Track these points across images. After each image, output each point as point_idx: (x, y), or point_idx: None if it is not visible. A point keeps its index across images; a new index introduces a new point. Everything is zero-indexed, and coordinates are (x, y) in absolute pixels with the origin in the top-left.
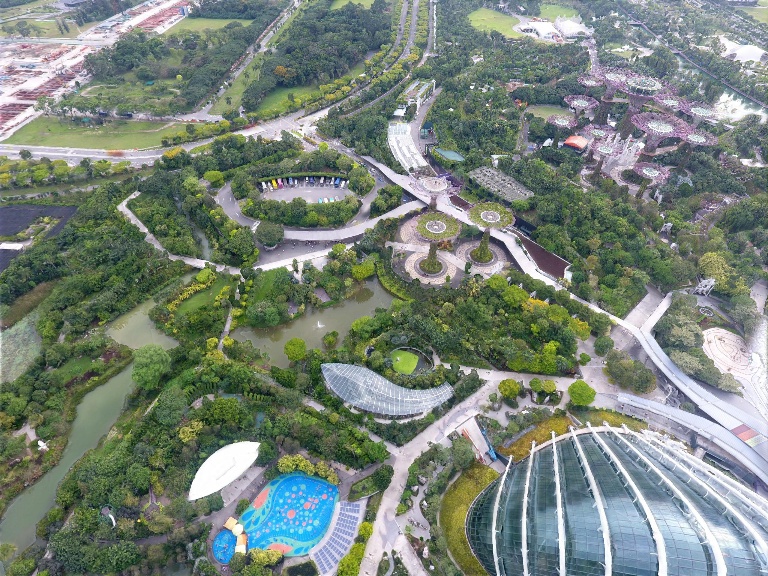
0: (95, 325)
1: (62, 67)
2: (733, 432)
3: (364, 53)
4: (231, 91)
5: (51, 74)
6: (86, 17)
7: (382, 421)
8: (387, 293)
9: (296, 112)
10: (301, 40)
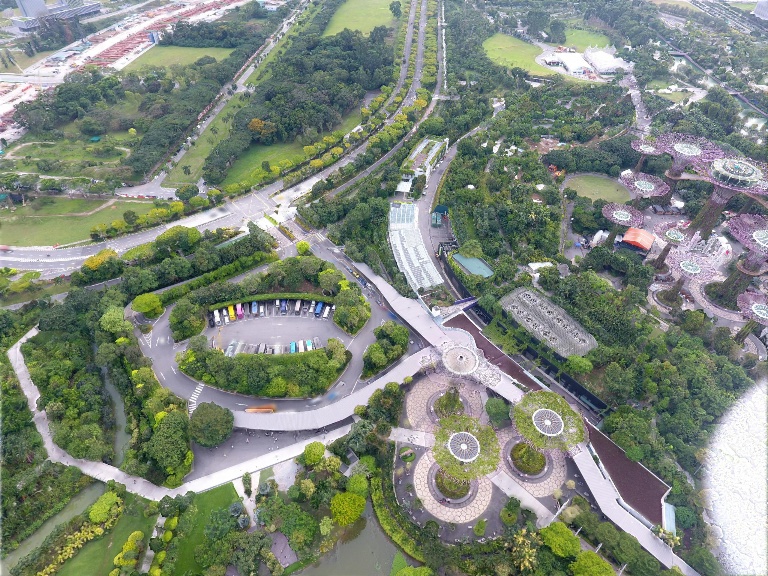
0: None
1: None
2: None
3: (361, 97)
4: (194, 151)
5: None
6: (38, 46)
7: None
8: (386, 539)
9: (273, 183)
10: (285, 81)
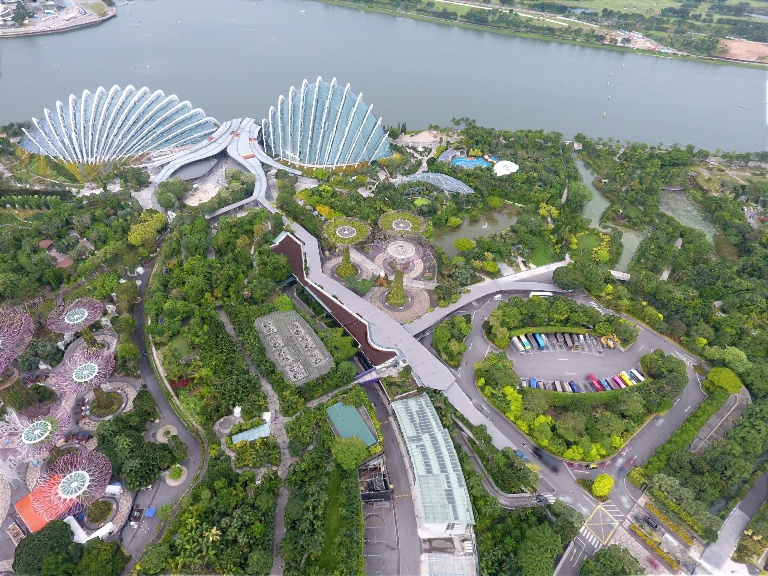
0: None
1: None
2: (255, 156)
3: None
4: None
5: None
6: None
7: None
8: None
9: None
10: None
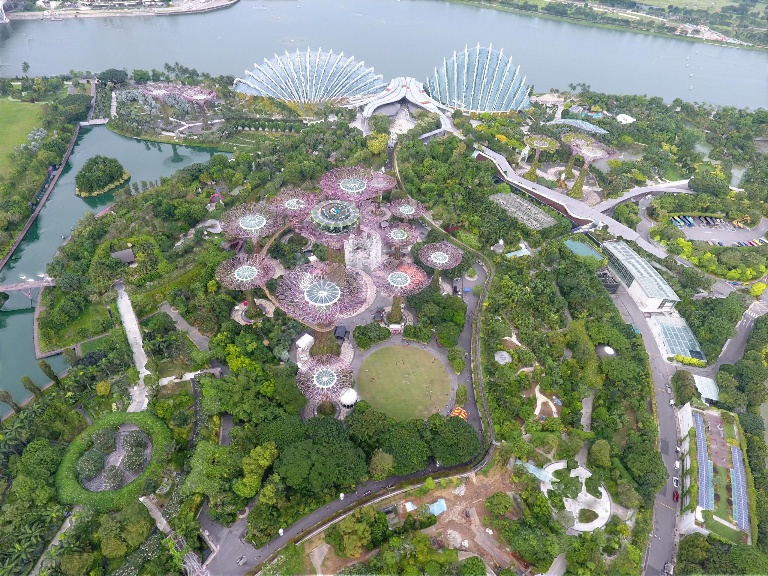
0: None
1: None
2: None
3: None
4: None
5: None
6: None
7: None
8: None
9: None
10: None
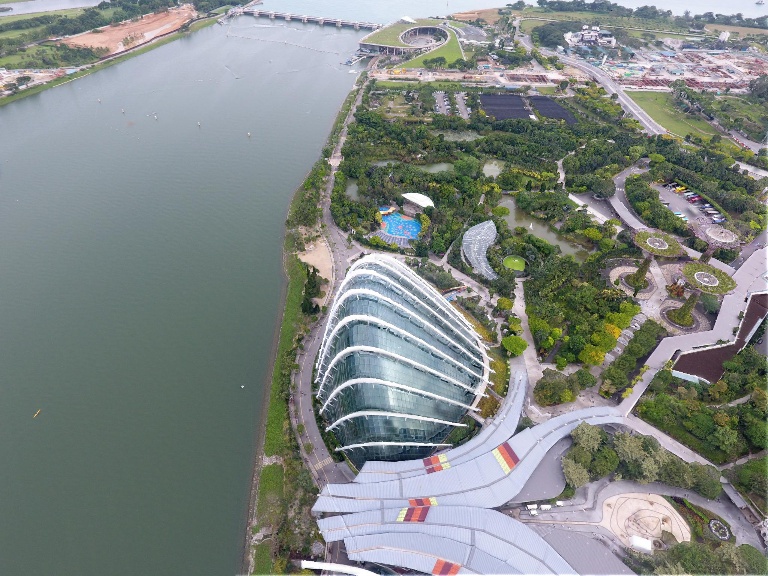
0: (493, 155)
1: (748, 80)
2: (505, 443)
3: None
4: None
5: (732, 80)
6: None
7: (462, 252)
8: None
9: None
10: None
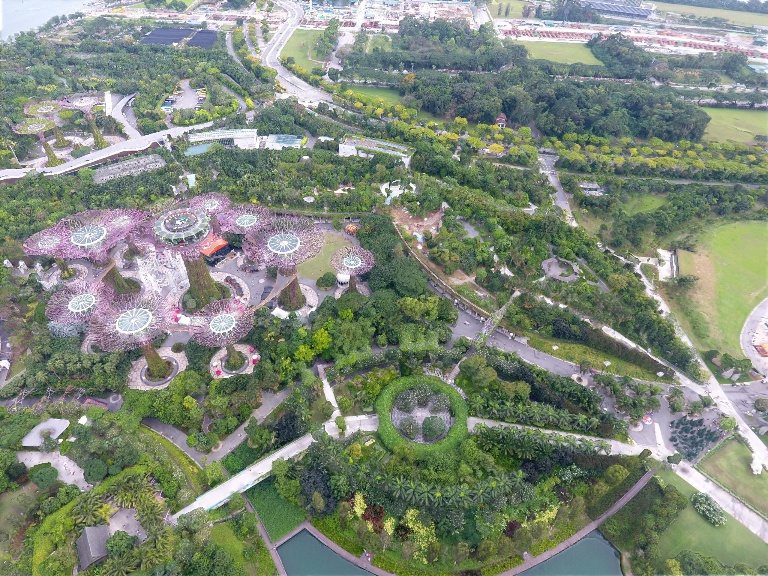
0: None
1: None
2: None
3: (492, 118)
4: None
5: None
6: (539, 13)
7: None
8: None
9: None
10: None
